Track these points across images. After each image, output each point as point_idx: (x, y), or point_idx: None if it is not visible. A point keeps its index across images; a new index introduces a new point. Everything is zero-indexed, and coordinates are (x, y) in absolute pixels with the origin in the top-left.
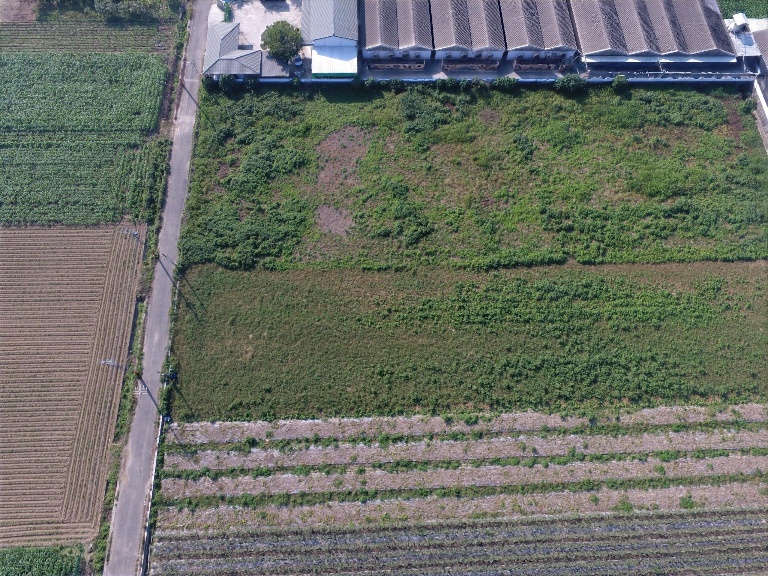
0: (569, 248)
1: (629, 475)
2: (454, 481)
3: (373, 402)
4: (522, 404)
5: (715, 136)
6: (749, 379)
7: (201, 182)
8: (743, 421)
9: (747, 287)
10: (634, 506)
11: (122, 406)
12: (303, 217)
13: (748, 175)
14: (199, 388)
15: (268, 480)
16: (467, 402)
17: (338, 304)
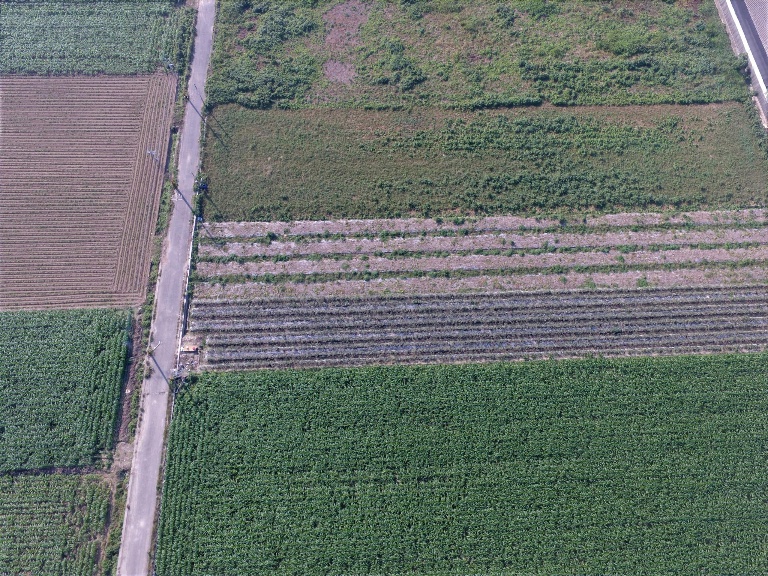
0: (545, 94)
1: (593, 262)
2: (444, 266)
3: (375, 207)
4: (502, 210)
5: (676, 7)
6: (699, 192)
7: (223, 42)
8: (693, 223)
9: (700, 124)
10: (597, 285)
11: (161, 209)
12: (313, 68)
13: (704, 37)
14: (226, 196)
15: (286, 264)
16: (455, 208)
17: (344, 135)
